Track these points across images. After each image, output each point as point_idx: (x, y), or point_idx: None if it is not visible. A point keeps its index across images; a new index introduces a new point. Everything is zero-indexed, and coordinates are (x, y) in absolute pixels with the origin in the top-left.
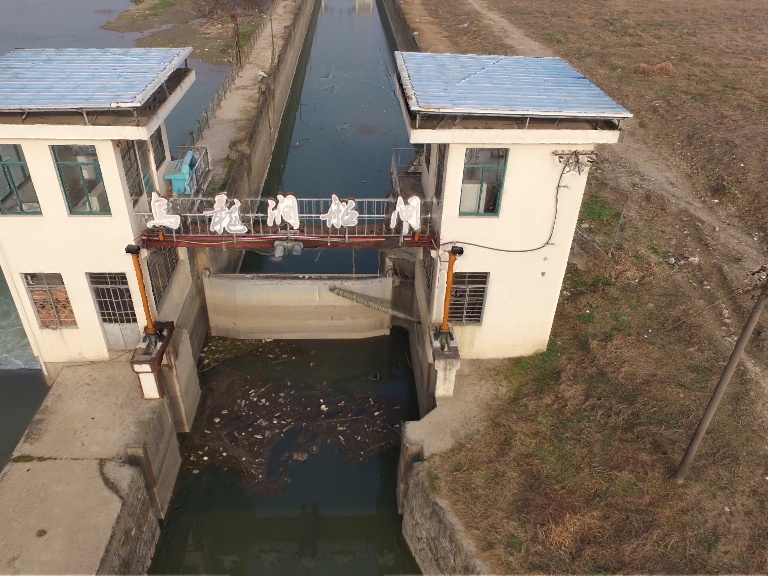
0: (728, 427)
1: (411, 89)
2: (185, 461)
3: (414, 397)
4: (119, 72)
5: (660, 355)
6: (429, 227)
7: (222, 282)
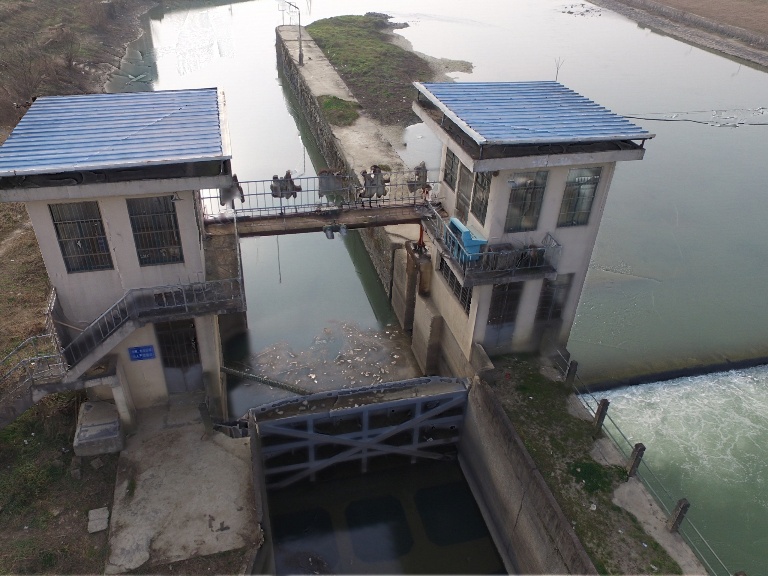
0: (8, 278)
1: (220, 100)
2: (401, 329)
3: (231, 401)
4: (486, 109)
5: (2, 323)
6: (209, 232)
7: (447, 385)
